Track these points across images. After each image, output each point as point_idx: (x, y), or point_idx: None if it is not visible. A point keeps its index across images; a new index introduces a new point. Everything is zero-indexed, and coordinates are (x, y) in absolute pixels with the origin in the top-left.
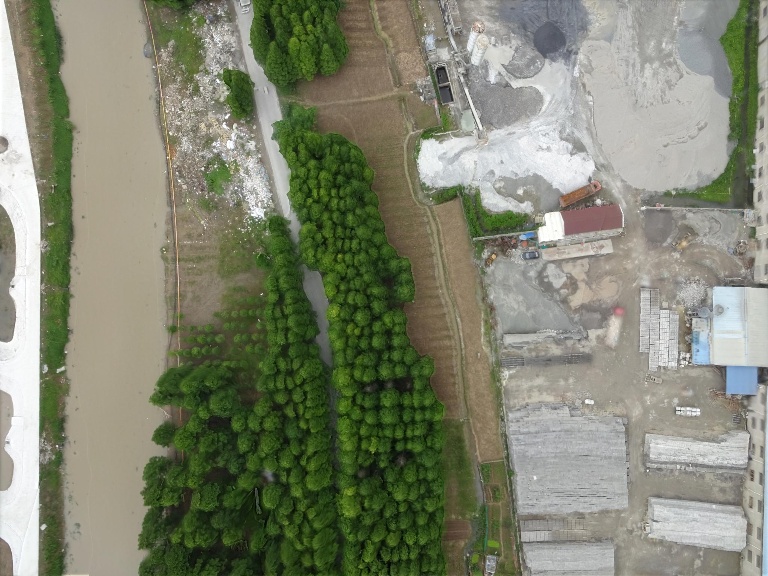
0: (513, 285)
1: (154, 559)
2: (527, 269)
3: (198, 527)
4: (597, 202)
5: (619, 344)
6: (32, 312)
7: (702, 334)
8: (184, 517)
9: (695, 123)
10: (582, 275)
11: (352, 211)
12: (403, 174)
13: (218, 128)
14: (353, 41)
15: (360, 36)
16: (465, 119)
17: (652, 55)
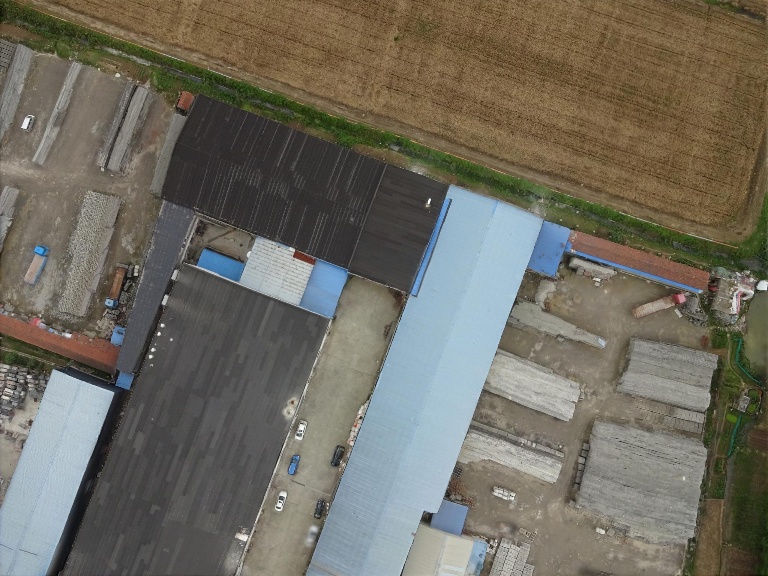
0: None
1: None
2: None
3: None
4: None
5: None
6: None
7: (471, 571)
8: None
9: None
10: None
11: None
12: None
13: None
14: None
15: None
16: None
17: None
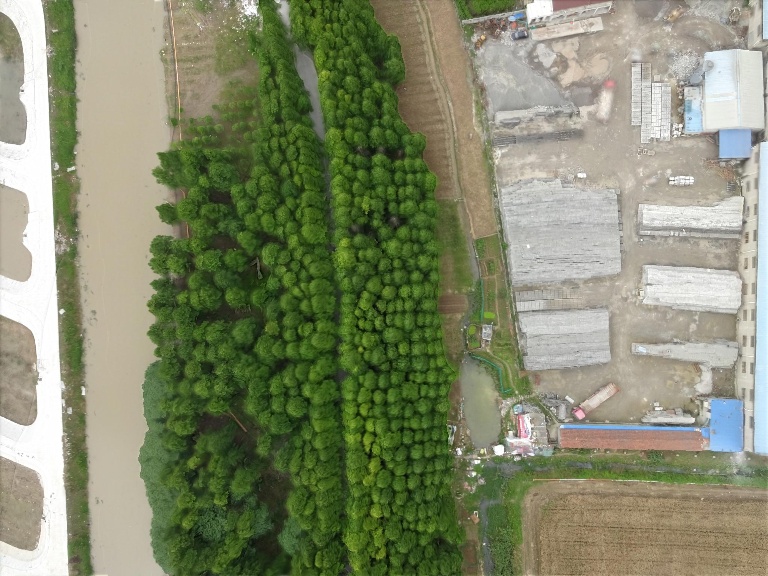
0: (503, 66)
1: (162, 316)
2: (517, 50)
3: (202, 285)
4: None
5: (611, 119)
6: (41, 113)
7: (694, 102)
8: (189, 279)
9: None
10: (572, 54)
11: None
12: None
13: None
14: None
15: None
16: None
17: None
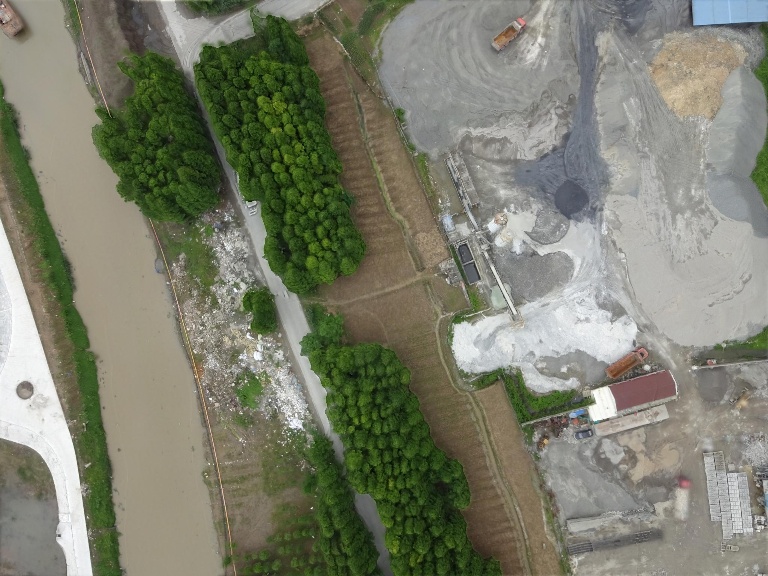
0: (570, 468)
1: None
2: (582, 448)
3: None
4: (645, 368)
5: (688, 515)
6: (83, 560)
7: None
8: None
9: (739, 276)
10: (640, 446)
11: (397, 432)
12: (439, 362)
13: (242, 340)
14: (368, 228)
15: (374, 221)
16: (495, 295)
17: (682, 204)
